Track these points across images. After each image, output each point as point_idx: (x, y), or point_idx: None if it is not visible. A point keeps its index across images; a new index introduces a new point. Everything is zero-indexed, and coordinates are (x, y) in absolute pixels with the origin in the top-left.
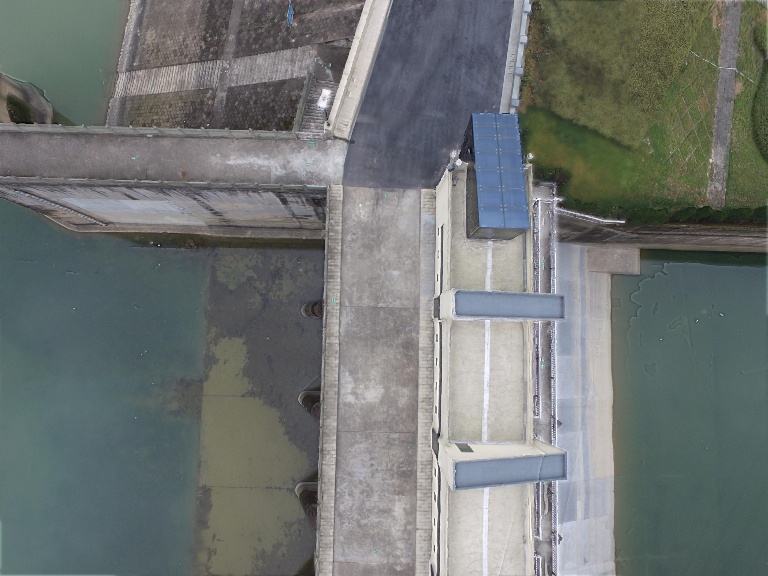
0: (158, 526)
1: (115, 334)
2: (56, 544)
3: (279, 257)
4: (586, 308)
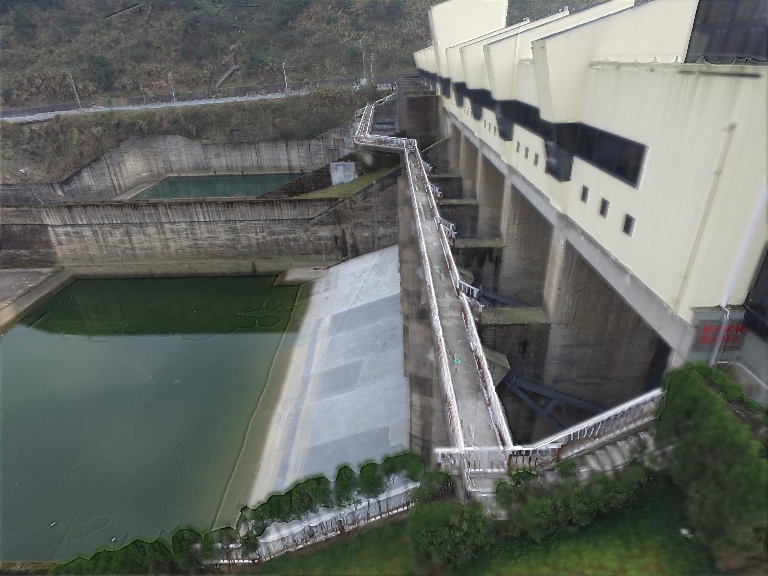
0: None
1: None
2: None
3: None
4: None
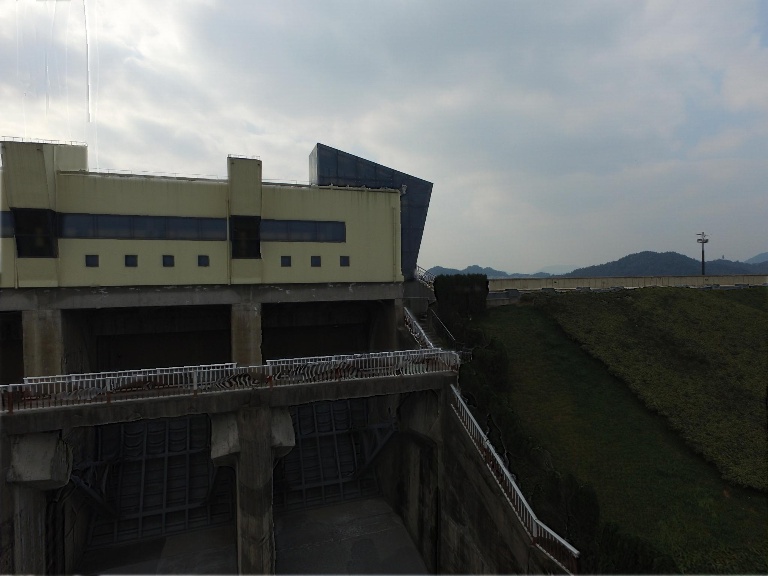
0: None
1: None
2: None
3: None
4: None
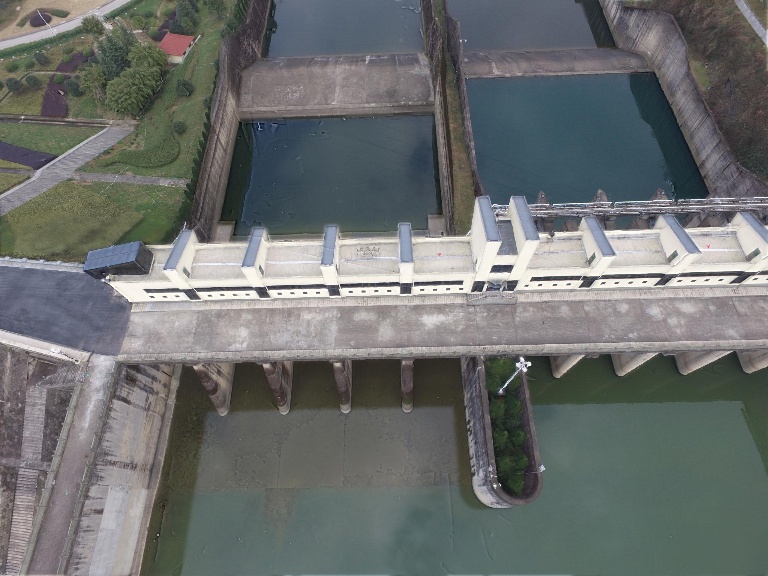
0: (372, 518)
1: (224, 570)
2: None
3: (183, 435)
4: None
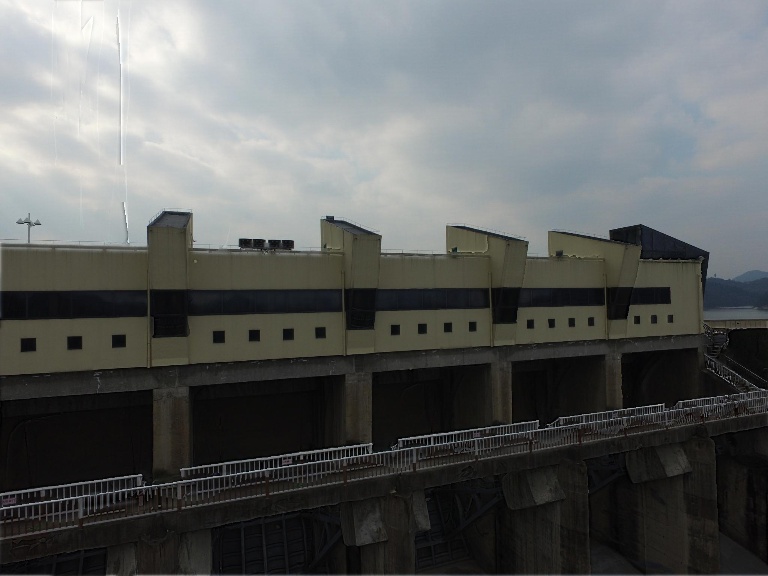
0: None
1: None
2: None
3: None
4: None
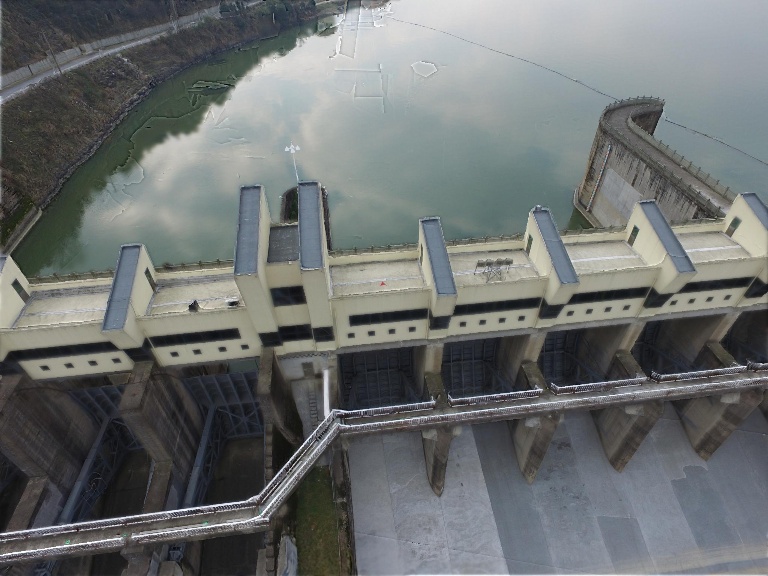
0: None
1: None
2: (398, 222)
3: None
4: (766, 567)
